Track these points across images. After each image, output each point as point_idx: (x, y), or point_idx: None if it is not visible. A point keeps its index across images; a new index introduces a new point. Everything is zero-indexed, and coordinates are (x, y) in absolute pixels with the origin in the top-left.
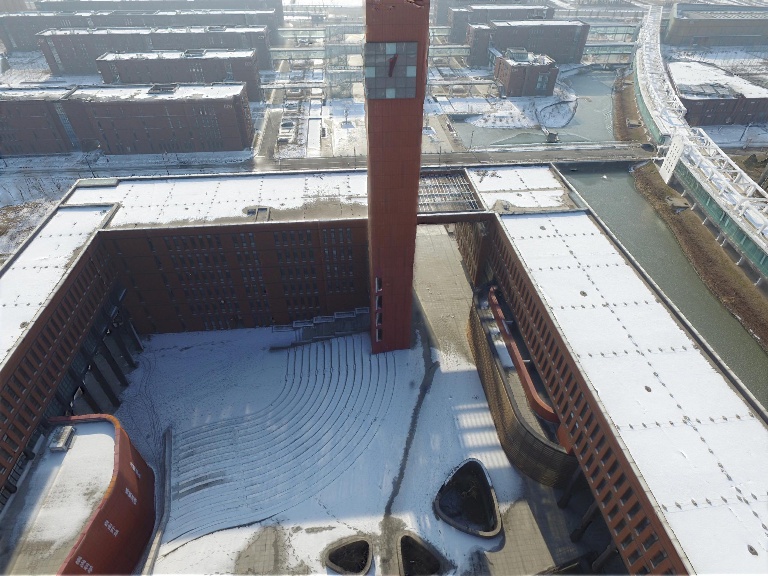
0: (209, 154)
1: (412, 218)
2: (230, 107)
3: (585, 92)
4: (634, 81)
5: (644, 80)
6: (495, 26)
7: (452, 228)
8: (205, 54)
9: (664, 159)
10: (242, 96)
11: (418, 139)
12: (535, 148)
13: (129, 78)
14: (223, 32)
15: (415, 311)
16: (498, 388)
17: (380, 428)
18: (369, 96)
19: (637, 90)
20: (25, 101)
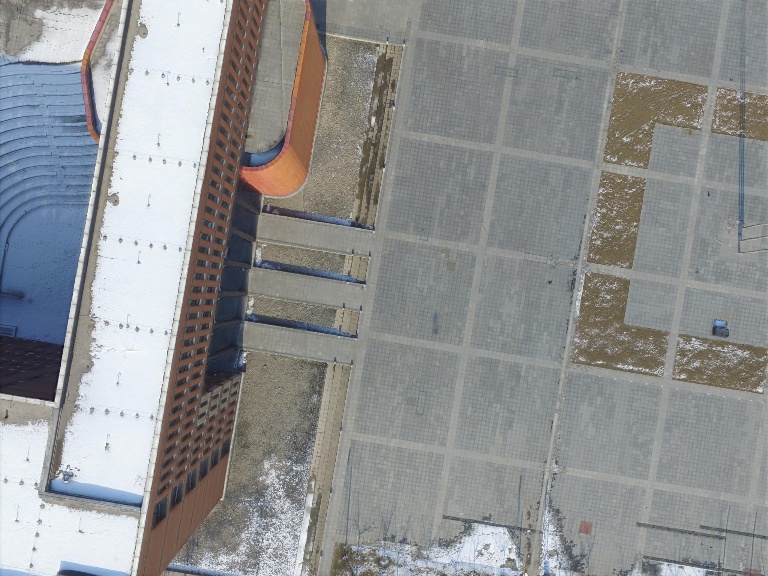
0: None
1: None
2: None
3: None
4: None
5: None
6: None
7: None
8: None
9: None
10: None
11: None
12: None
13: None
14: None
15: None
16: None
17: None
18: None
19: None
20: None
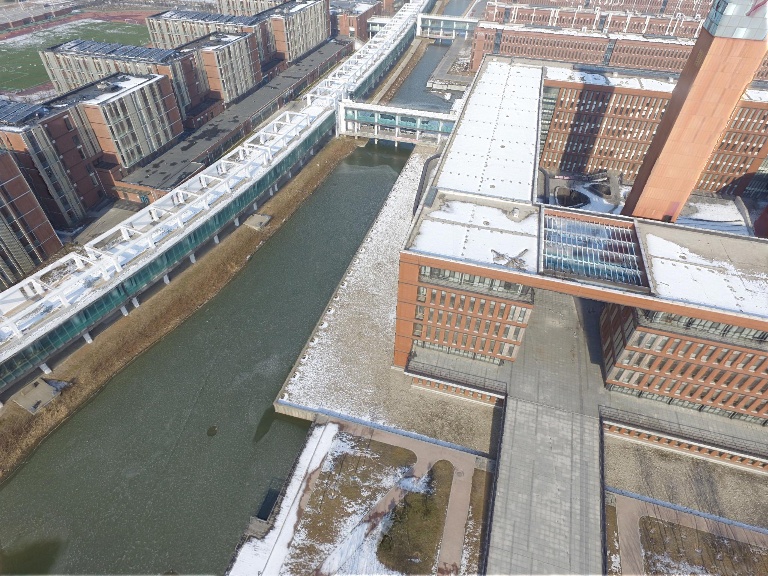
0: None
1: None
2: None
3: None
4: None
5: None
6: None
7: (470, 465)
8: None
9: None
10: None
11: None
12: None
13: None
14: None
15: (583, 299)
16: None
17: None
18: None
19: None
20: None
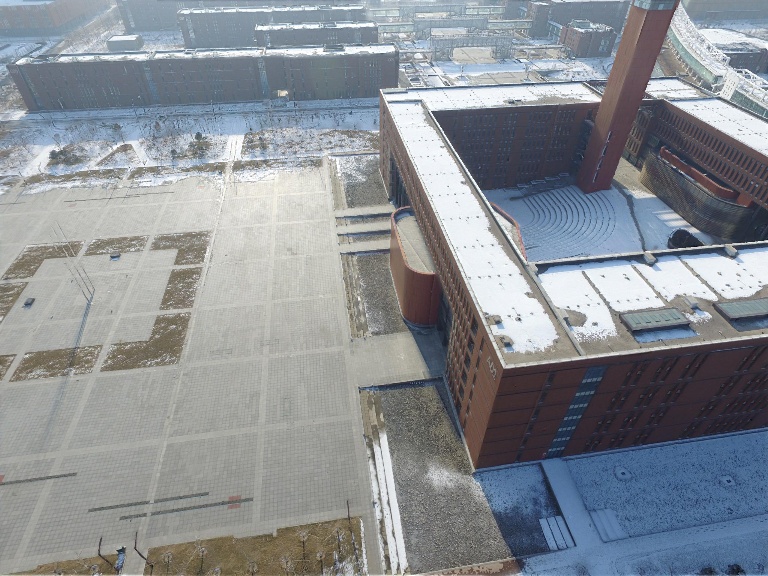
0: (370, 99)
1: (644, 88)
2: (393, 60)
3: None
4: (674, 44)
5: (685, 42)
6: (554, 3)
7: None
8: (337, 25)
9: (720, 93)
10: None
11: (664, 35)
12: None
13: (278, 45)
14: (332, 10)
15: None
16: (688, 191)
17: (616, 221)
18: (649, 8)
19: (680, 50)
20: (238, 57)
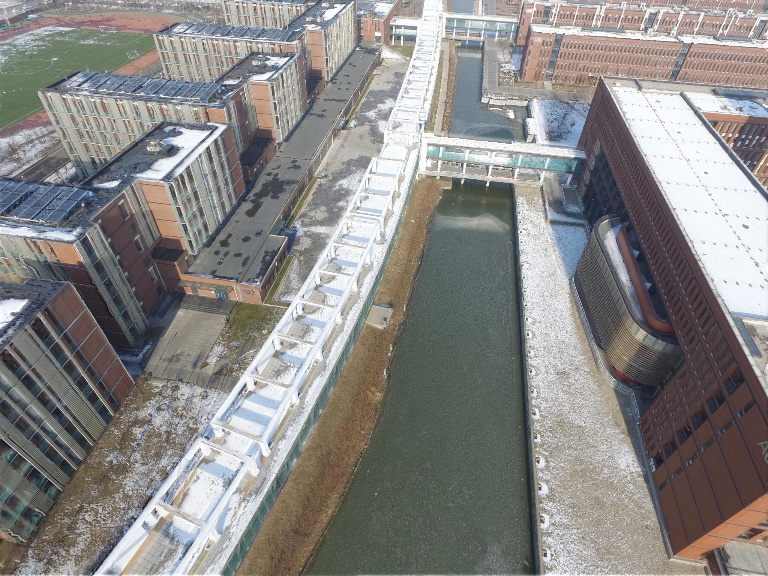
0: None
1: None
2: None
3: None
4: None
5: None
6: None
7: None
8: None
9: None
10: None
11: None
12: None
13: None
14: None
15: None
16: None
17: None
18: None
19: None
20: None
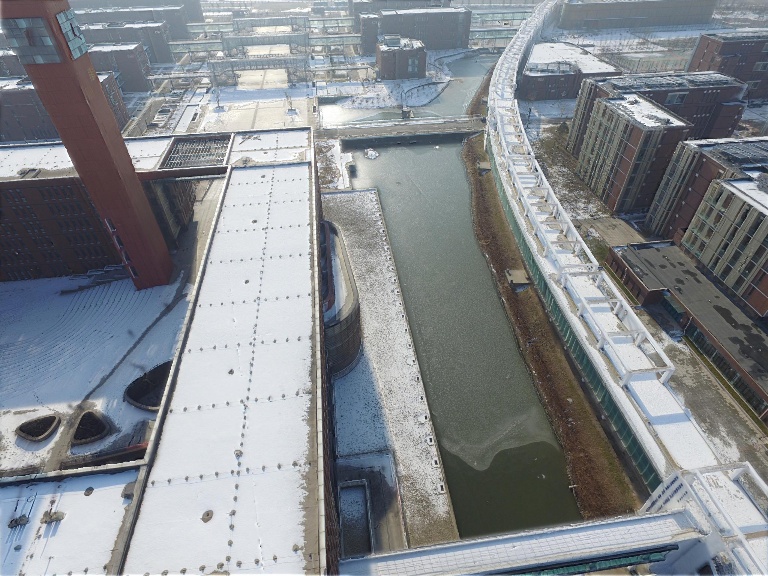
0: None
1: (110, 165)
2: None
3: (462, 74)
4: None
5: (503, 60)
6: (382, 15)
7: None
8: (91, 48)
9: None
10: (106, 84)
11: (82, 97)
12: (383, 124)
13: (19, 73)
14: (120, 28)
15: (188, 256)
16: None
17: (112, 342)
18: (22, 62)
19: None
20: None
